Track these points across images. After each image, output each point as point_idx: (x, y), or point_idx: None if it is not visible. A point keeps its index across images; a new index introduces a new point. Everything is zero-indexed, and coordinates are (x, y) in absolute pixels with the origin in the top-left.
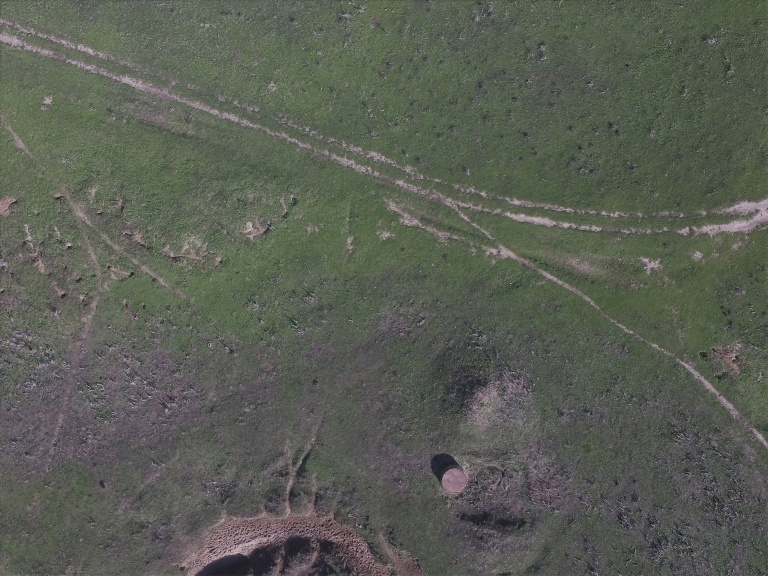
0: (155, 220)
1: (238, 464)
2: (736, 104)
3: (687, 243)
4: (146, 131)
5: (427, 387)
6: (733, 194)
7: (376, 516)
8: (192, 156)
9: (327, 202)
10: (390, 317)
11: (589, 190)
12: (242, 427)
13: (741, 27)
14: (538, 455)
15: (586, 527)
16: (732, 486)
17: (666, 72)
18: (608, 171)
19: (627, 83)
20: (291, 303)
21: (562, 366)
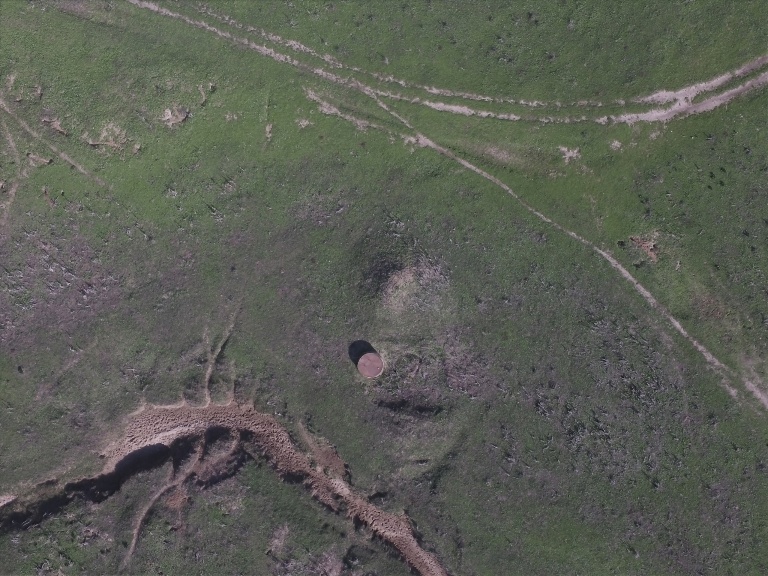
0: (73, 107)
1: (156, 351)
2: None
3: (605, 132)
4: (65, 19)
5: (345, 274)
6: (651, 83)
7: (294, 403)
8: (111, 44)
9: (246, 90)
10: (309, 205)
11: (508, 79)
12: (160, 314)
13: None
14: (455, 341)
15: (503, 414)
16: (649, 374)
17: None
18: (527, 61)
19: None
20: (210, 190)
21: (480, 254)
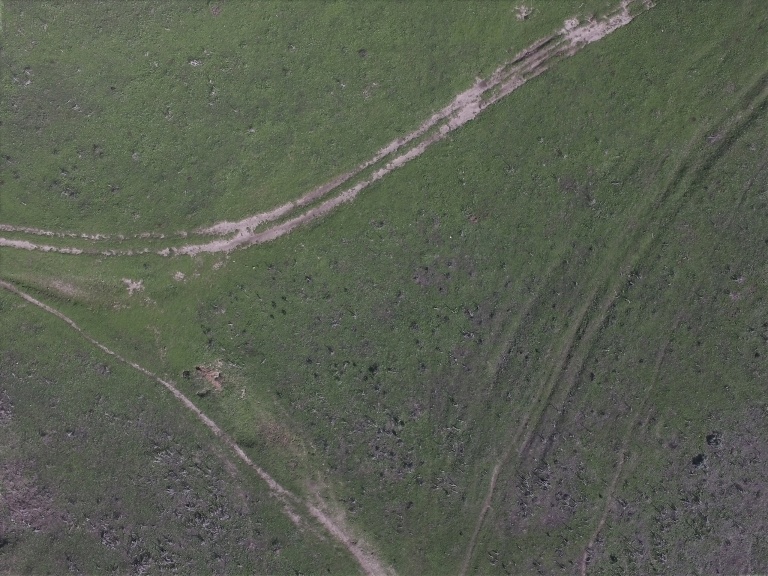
0: None
1: None
2: (218, 125)
3: (167, 264)
4: None
5: None
6: (213, 214)
7: None
8: None
9: None
10: None
11: (69, 213)
12: None
13: (226, 49)
14: (16, 476)
15: (69, 545)
16: (214, 502)
17: (152, 94)
18: (90, 194)
19: (112, 106)
20: None
21: (44, 387)
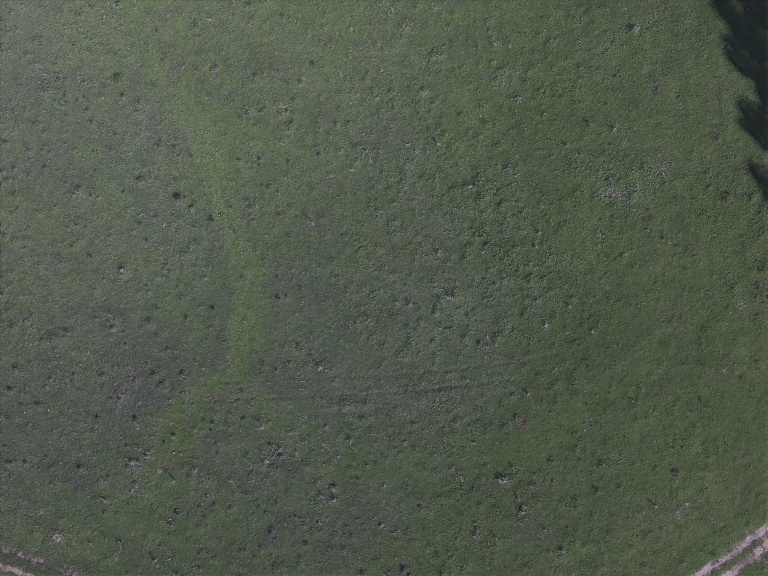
0: None
1: None
2: (527, 546)
3: None
4: None
5: None
6: None
7: None
8: None
9: None
10: None
11: None
12: None
13: (533, 463)
14: None
15: None
16: None
17: (458, 511)
18: None
19: (418, 523)
20: None
21: None
